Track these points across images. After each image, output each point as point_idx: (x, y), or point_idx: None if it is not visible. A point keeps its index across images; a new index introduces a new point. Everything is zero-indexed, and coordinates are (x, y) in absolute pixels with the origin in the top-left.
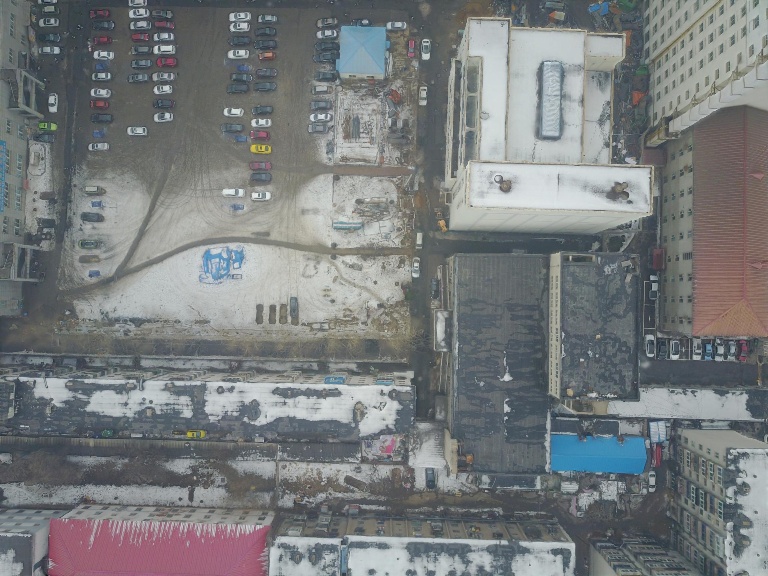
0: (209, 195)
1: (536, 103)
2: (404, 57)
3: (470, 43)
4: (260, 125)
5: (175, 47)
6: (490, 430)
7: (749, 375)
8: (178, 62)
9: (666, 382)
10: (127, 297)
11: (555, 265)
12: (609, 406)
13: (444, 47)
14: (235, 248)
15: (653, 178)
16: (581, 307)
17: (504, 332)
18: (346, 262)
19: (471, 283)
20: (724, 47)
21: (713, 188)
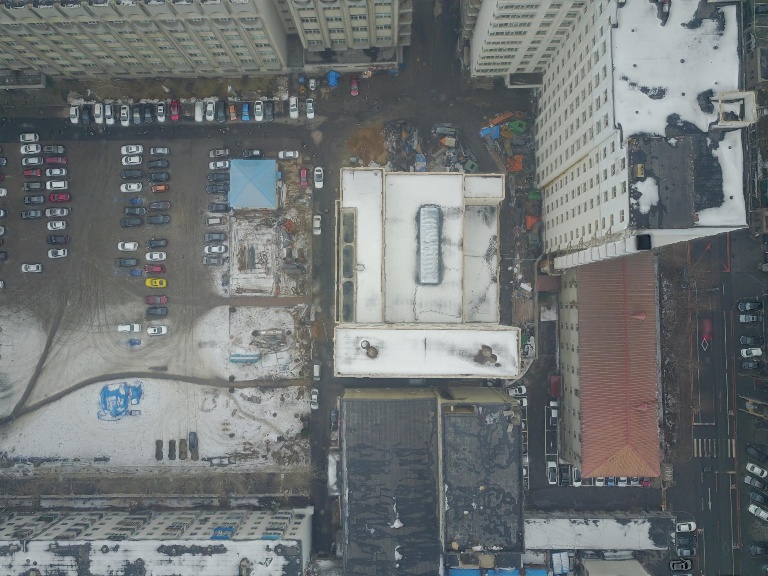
0: (106, 330)
1: (416, 248)
2: (298, 185)
3: (344, 194)
4: (154, 259)
5: (68, 182)
6: None
7: (653, 499)
8: (71, 197)
9: (570, 509)
10: (26, 436)
11: (439, 412)
12: None
13: (337, 174)
14: (133, 384)
15: None
16: (464, 458)
17: (393, 478)
18: (245, 395)
19: (359, 428)
20: (587, 207)
21: (597, 329)
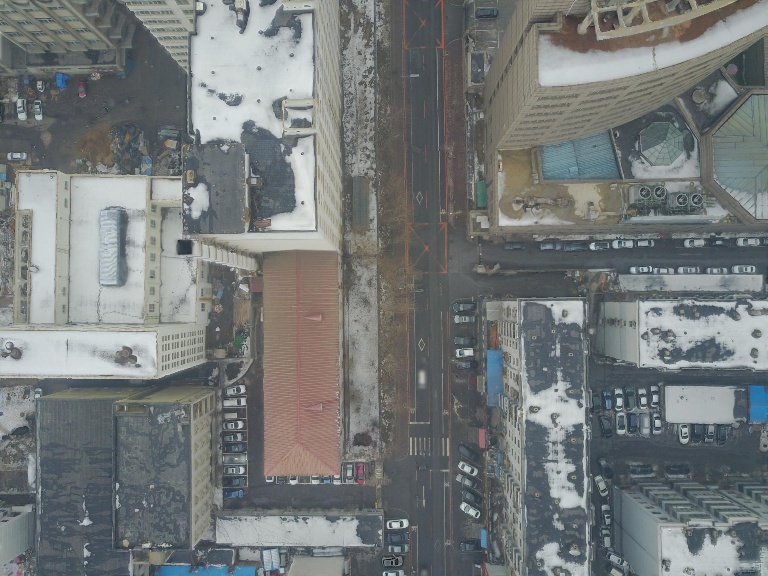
0: None
1: None
2: None
3: (20, 196)
4: None
5: None
6: (71, 575)
7: (369, 497)
8: None
9: (288, 506)
10: None
11: None
12: (222, 535)
13: None
14: None
15: (158, 342)
16: (135, 457)
17: (83, 476)
18: None
19: (52, 427)
20: None
21: (276, 330)
